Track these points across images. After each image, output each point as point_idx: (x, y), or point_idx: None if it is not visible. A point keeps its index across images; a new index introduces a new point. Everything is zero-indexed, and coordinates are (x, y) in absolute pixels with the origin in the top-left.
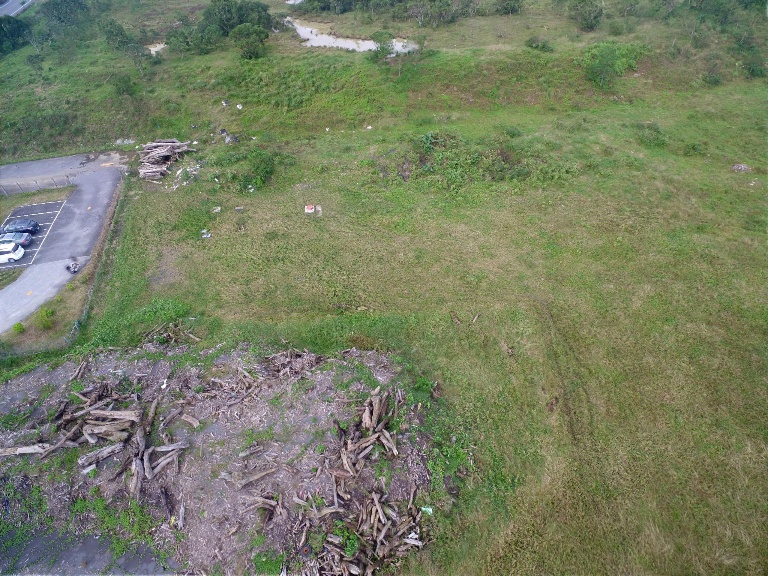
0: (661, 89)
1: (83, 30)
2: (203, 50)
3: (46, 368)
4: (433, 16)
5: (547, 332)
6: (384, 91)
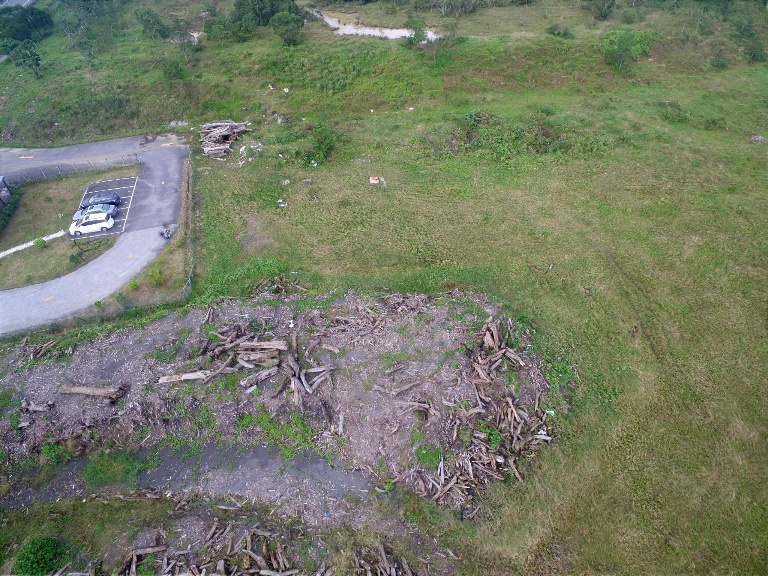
0: (674, 72)
1: (116, 20)
2: (241, 38)
3: (176, 315)
4: (456, 6)
5: (616, 276)
6: (421, 75)
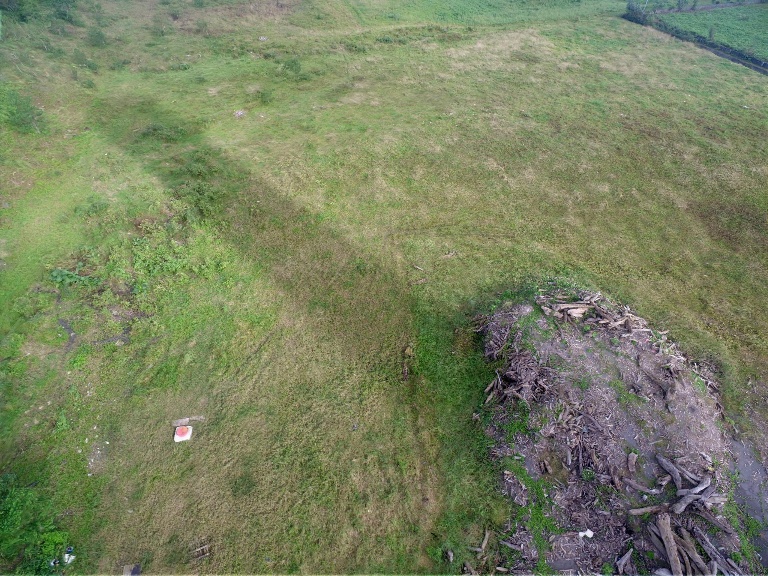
0: (77, 109)
1: None
2: None
3: None
4: None
5: (427, 234)
6: None
